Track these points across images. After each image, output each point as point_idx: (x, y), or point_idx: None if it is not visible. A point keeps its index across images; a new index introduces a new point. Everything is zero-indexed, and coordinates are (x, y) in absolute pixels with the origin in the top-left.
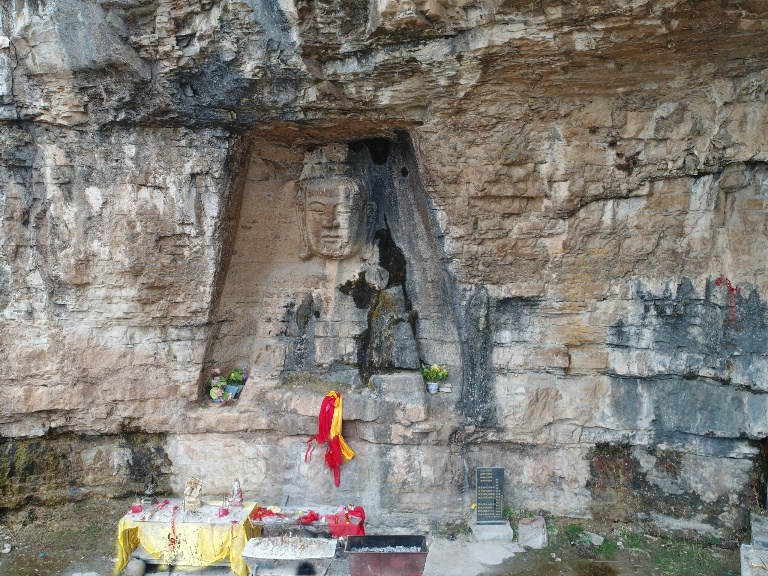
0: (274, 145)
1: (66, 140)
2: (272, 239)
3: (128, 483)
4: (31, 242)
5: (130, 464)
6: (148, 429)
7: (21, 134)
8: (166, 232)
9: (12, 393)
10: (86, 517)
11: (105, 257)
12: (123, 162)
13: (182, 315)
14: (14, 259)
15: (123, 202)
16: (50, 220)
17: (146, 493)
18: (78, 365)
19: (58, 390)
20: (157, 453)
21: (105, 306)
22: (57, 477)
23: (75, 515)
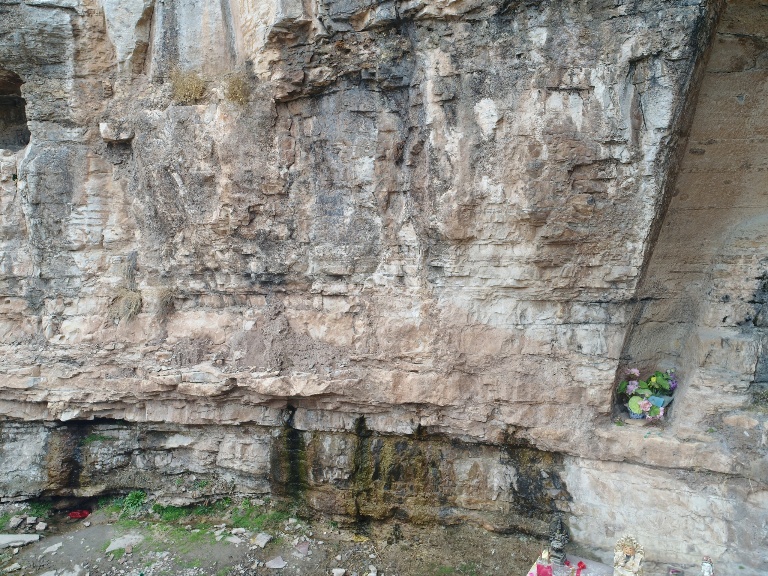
0: (758, 8)
1: (452, 39)
2: (737, 170)
3: (511, 514)
4: (405, 186)
5: (514, 489)
6: (539, 445)
7: (399, 41)
8: (584, 158)
9: (380, 377)
10: (460, 550)
11: (497, 199)
12: (528, 57)
13: (597, 285)
14: (385, 209)
15: (525, 117)
16: (429, 153)
17: (553, 545)
18: (454, 348)
19: (430, 379)
20: (550, 480)
21: (491, 270)
22: (425, 489)
23: (446, 544)
